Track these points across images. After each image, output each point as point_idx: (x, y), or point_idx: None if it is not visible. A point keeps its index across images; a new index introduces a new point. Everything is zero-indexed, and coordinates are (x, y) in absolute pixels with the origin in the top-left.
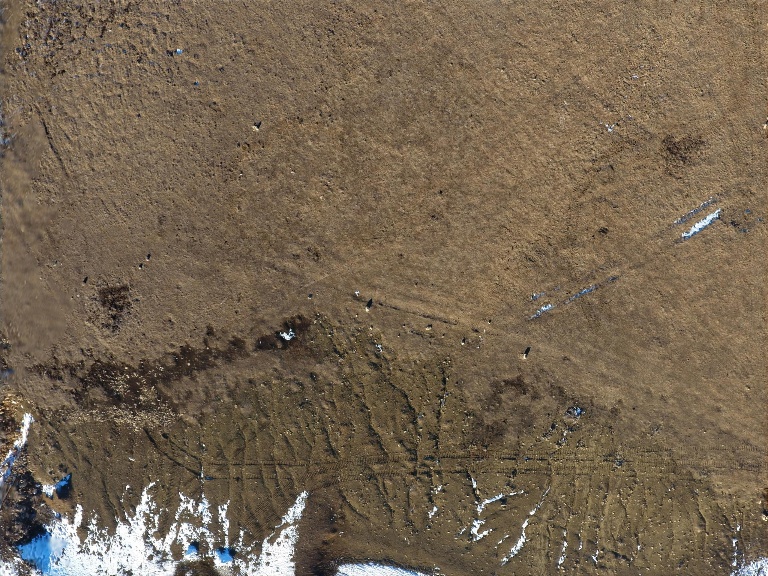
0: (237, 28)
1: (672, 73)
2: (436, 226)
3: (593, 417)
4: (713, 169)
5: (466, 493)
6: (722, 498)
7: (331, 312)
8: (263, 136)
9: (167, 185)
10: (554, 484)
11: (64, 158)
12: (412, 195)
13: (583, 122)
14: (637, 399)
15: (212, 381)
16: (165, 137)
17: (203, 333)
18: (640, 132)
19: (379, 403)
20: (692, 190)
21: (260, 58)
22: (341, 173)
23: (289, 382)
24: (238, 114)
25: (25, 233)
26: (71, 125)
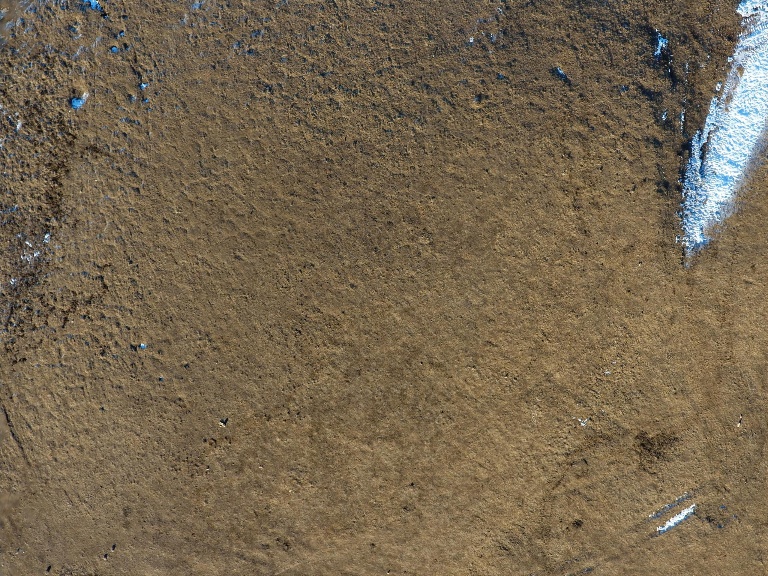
0: (202, 326)
1: (645, 370)
2: (408, 517)
3: None
4: (687, 465)
5: None
6: None
7: None
8: (230, 432)
9: (132, 478)
10: None
11: (26, 447)
12: (383, 487)
13: (556, 417)
14: None
15: None
16: (129, 431)
17: None
18: (613, 427)
19: None
20: (666, 485)
21: (226, 356)
22: (310, 468)
23: None
24: (204, 410)
25: None
26: (33, 414)
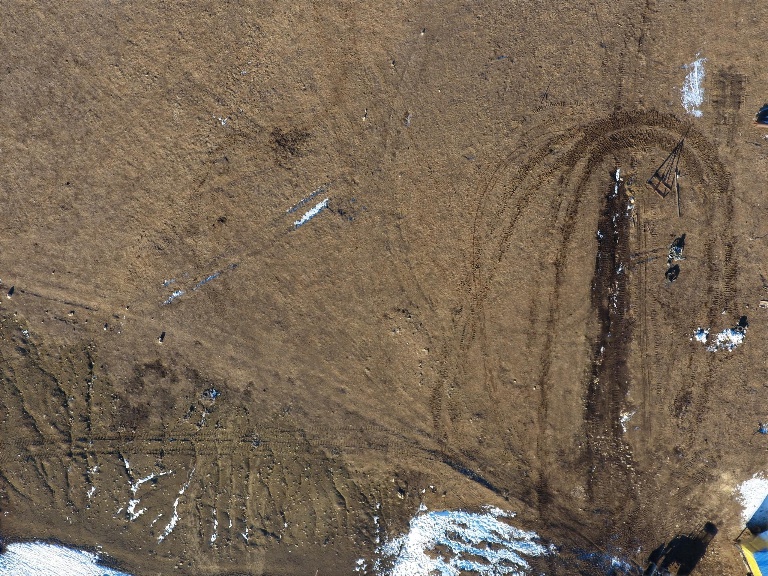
0: None
1: (277, 69)
2: (66, 216)
3: (228, 399)
4: (319, 160)
5: (119, 473)
6: (357, 476)
7: None
8: None
9: None
10: (198, 464)
11: None
12: (41, 186)
13: (197, 116)
14: (266, 381)
15: None
16: None
17: None
18: (251, 125)
19: (30, 387)
20: (301, 180)
21: None
22: None
23: None
24: None
25: None
26: None
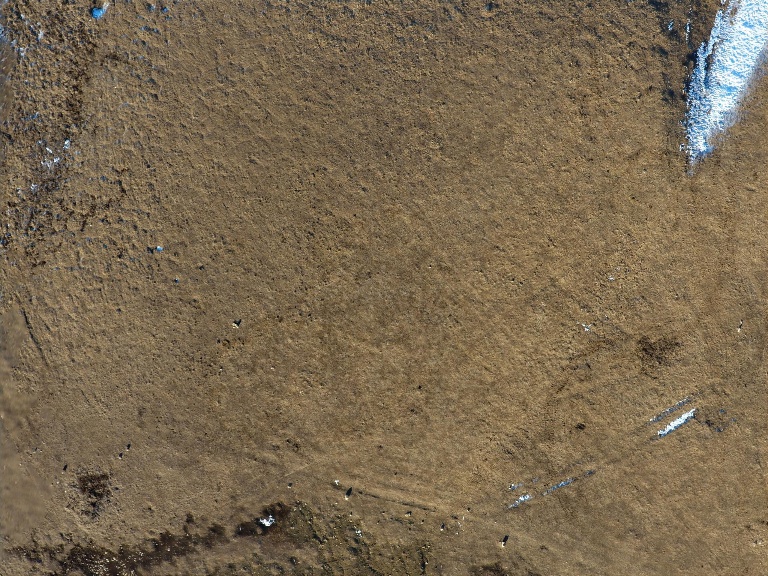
0: (217, 228)
1: (648, 276)
2: (415, 420)
3: None
4: (688, 370)
5: None
6: None
7: (311, 500)
8: (243, 333)
9: (147, 378)
10: None
11: (44, 348)
12: (391, 390)
13: (560, 322)
14: None
15: (192, 566)
16: (145, 332)
17: (183, 521)
18: (616, 332)
19: None
20: (667, 390)
21: (240, 258)
22: (321, 369)
23: (269, 567)
24: (218, 311)
25: (5, 419)
26: (51, 316)
